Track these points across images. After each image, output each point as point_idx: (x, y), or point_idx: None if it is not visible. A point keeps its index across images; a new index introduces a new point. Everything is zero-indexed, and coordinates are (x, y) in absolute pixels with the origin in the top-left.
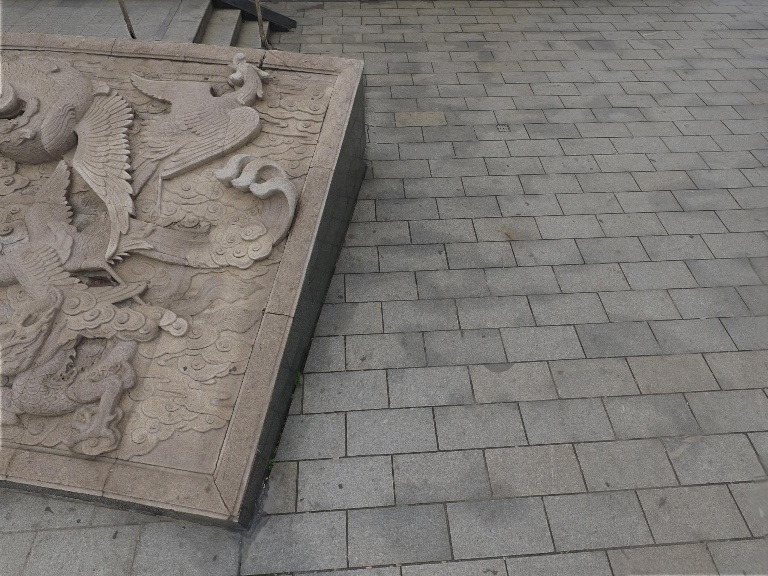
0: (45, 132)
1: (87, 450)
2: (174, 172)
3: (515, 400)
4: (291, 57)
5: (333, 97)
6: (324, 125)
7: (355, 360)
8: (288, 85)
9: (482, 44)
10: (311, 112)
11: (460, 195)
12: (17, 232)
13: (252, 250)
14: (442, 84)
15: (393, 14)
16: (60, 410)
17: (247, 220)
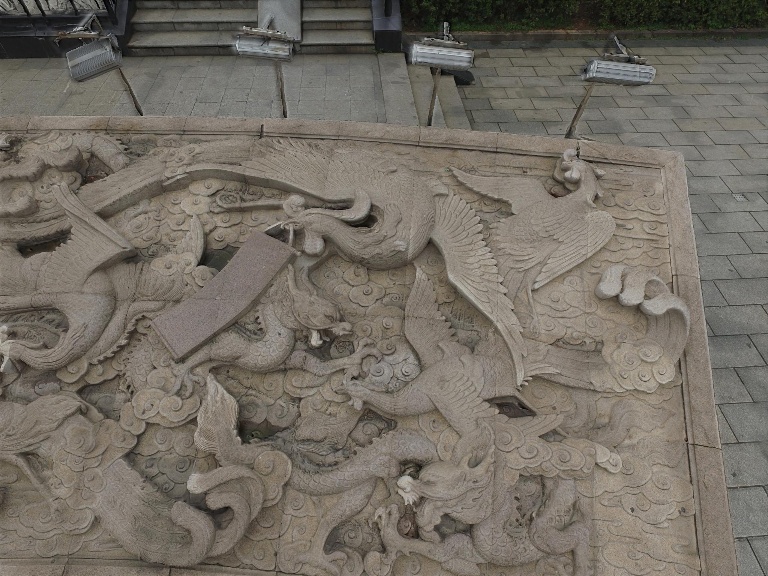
0: (413, 242)
1: None
2: (545, 283)
3: None
4: (610, 149)
5: (666, 194)
6: (669, 226)
7: (726, 475)
8: (613, 180)
9: (669, 98)
10: (654, 212)
11: (736, 277)
12: (400, 350)
13: (658, 373)
14: (653, 146)
15: (563, 63)
16: (528, 561)
17: (635, 337)
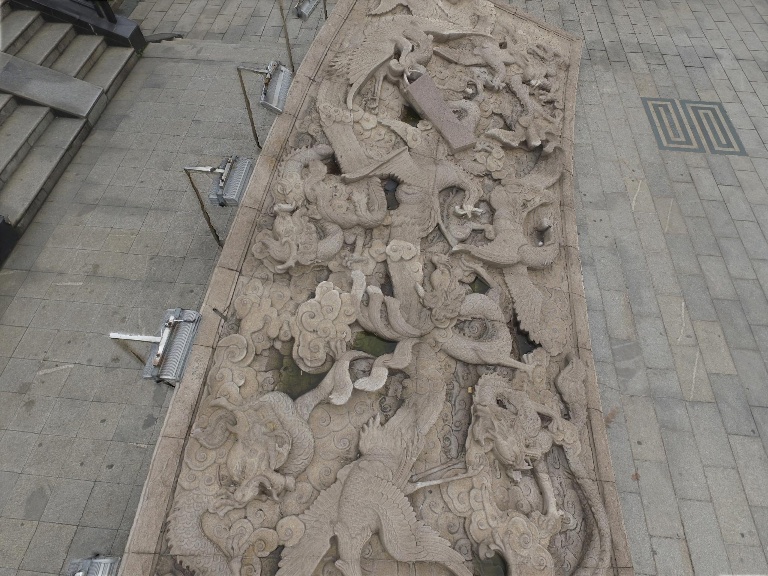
0: None
1: (568, 62)
2: None
3: (525, 1)
4: None
5: None
6: None
7: None
8: None
9: None
10: None
11: None
12: (473, 70)
13: (491, 5)
14: None
15: None
16: None
17: (474, 4)
